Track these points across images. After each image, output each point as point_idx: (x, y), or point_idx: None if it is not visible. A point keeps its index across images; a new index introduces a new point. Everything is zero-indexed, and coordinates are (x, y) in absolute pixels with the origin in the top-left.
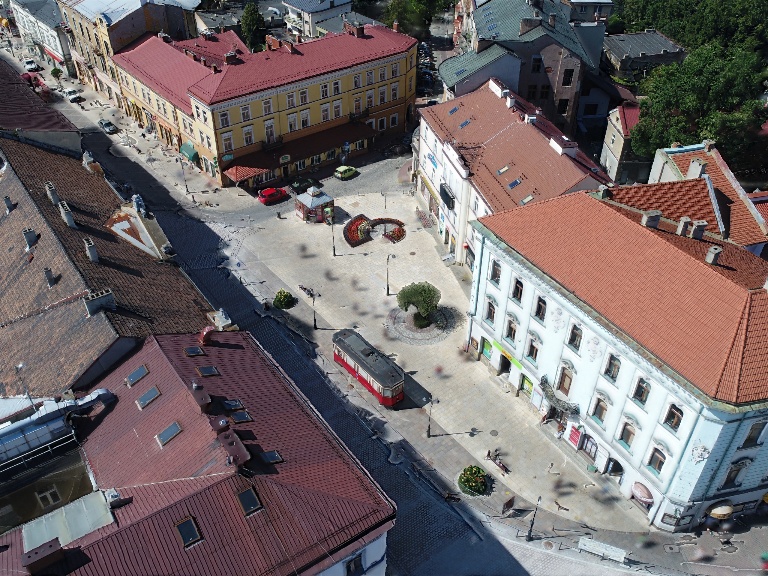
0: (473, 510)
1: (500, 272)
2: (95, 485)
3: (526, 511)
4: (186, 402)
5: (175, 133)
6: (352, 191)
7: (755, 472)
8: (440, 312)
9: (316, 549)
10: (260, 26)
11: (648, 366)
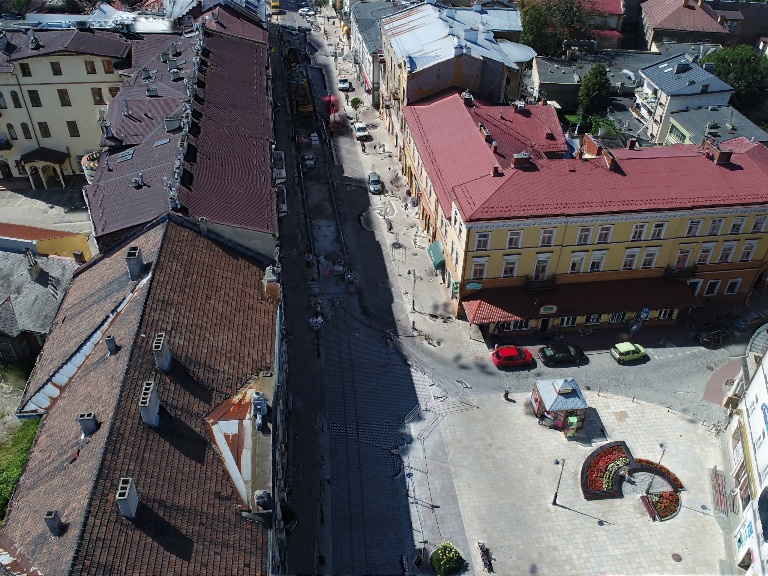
0: None
1: None
2: None
3: None
4: None
5: (432, 223)
6: (626, 388)
7: None
8: None
9: None
10: (602, 93)
11: None
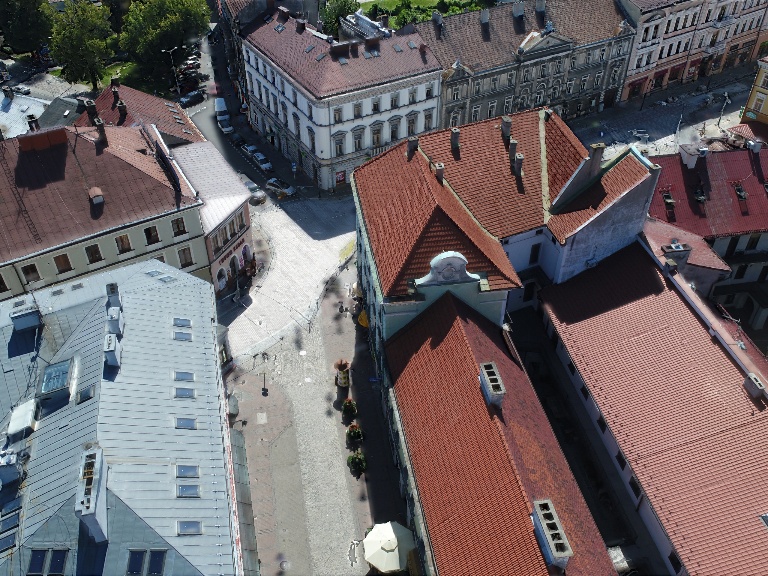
0: None
1: None
2: None
3: None
4: None
5: None
6: None
7: None
8: None
9: None
10: None
11: None
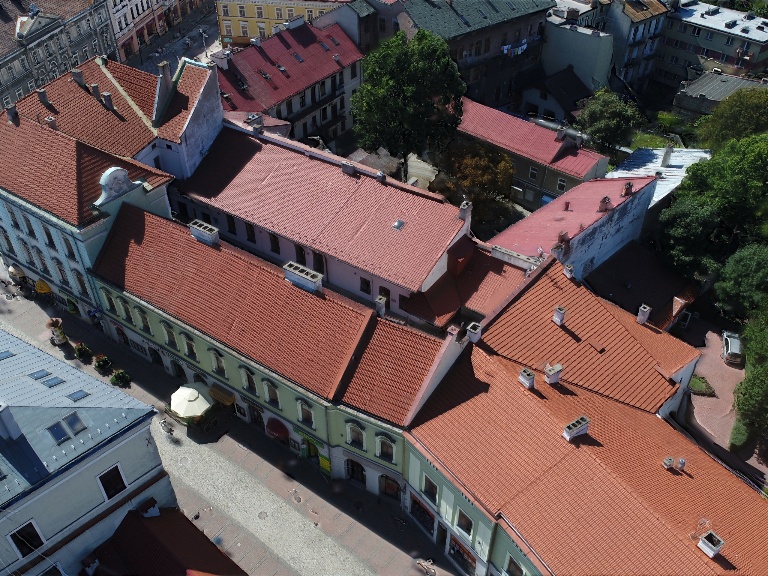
0: None
1: None
2: None
3: None
4: None
5: None
6: None
7: None
8: None
9: None
10: None
11: None
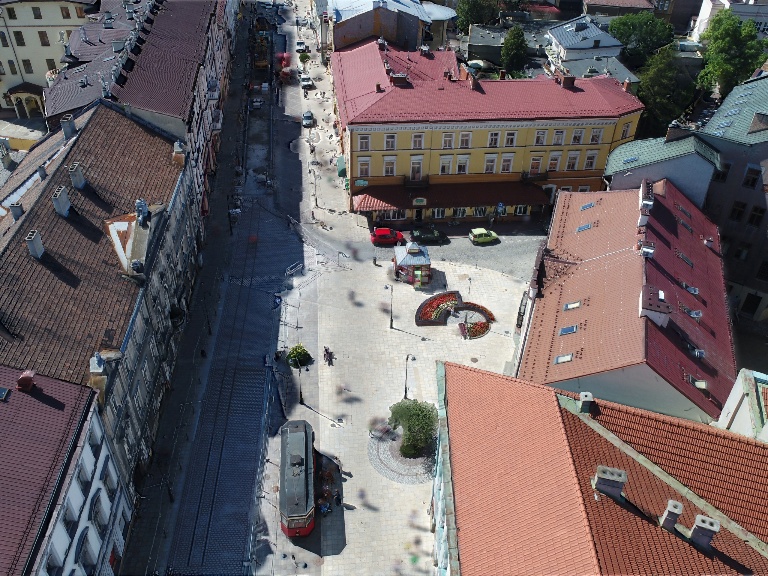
0: None
1: None
2: None
3: None
4: None
5: None
6: (474, 260)
7: None
8: None
9: None
10: (520, 52)
11: None
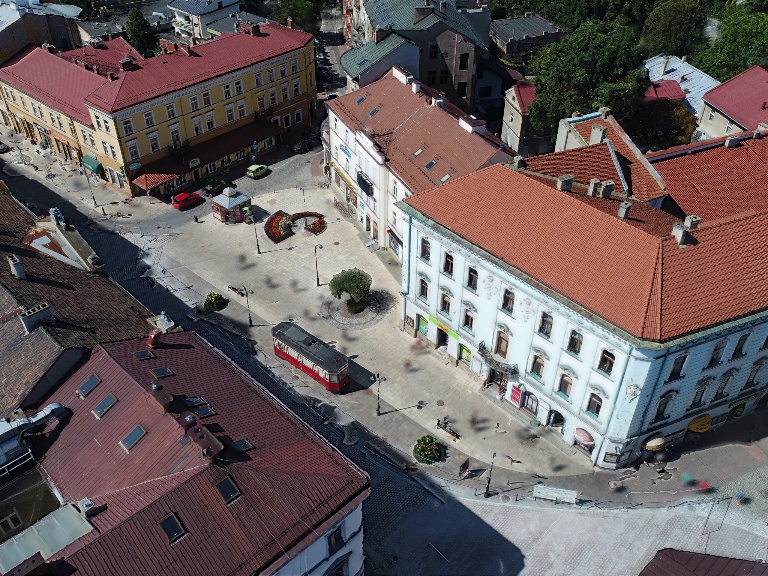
0: (431, 477)
1: (429, 249)
2: (62, 500)
3: (481, 471)
4: (146, 404)
5: (74, 146)
6: (267, 189)
7: (680, 403)
8: (372, 296)
9: (299, 526)
10: (147, 32)
11: (579, 318)
